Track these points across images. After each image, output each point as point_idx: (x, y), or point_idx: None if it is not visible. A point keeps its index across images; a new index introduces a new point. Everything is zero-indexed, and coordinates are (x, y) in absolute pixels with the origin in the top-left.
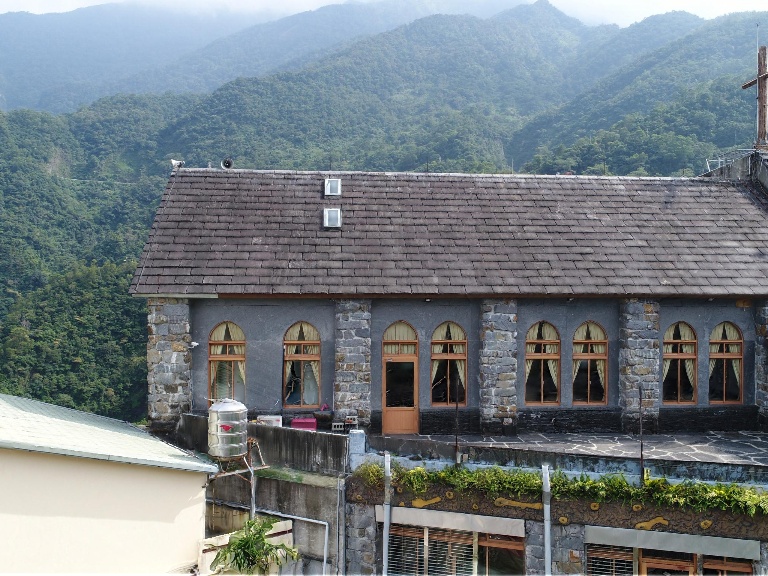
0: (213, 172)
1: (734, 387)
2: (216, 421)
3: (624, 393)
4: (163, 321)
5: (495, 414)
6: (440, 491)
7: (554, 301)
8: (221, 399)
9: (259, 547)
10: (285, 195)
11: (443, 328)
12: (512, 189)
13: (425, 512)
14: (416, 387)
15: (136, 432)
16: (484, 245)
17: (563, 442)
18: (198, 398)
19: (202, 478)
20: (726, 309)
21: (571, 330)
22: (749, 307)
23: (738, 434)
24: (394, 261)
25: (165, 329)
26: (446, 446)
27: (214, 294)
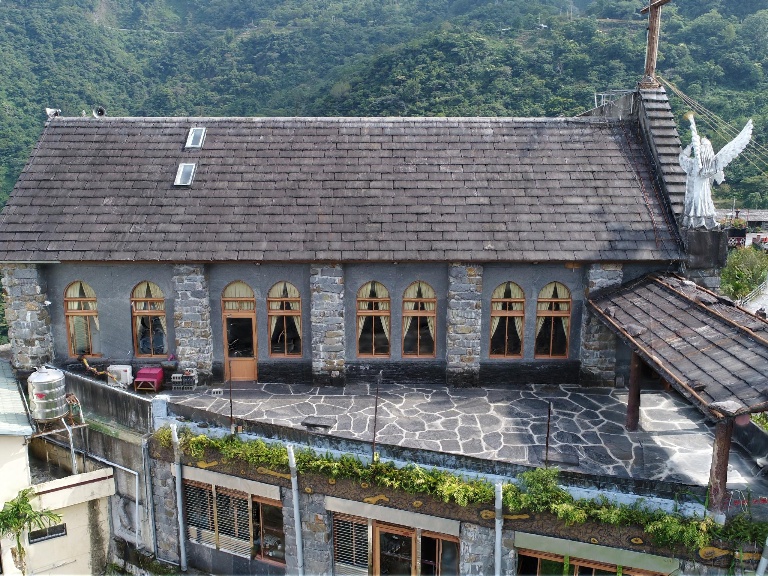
0: (85, 121)
1: (563, 342)
2: (31, 390)
3: (447, 349)
4: (15, 284)
5: (323, 367)
6: (217, 456)
7: (383, 262)
8: (41, 368)
9: (20, 517)
10: (148, 148)
11: (280, 286)
12: (375, 136)
13: (206, 472)
14: (255, 340)
15: (3, 379)
16: (324, 204)
17: (378, 396)
18: (59, 348)
19: (21, 438)
20: (555, 270)
21: (400, 289)
22: (579, 268)
23: (555, 388)
24: (231, 224)
25: (18, 291)
26: (225, 418)
27: (56, 261)
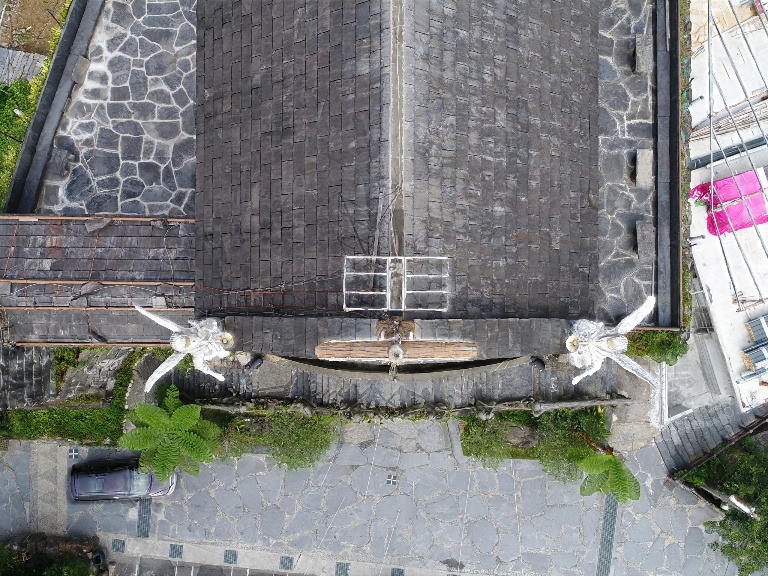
0: None
1: None
2: None
3: None
4: None
5: None
6: None
7: None
8: None
9: None
10: None
11: None
12: None
13: None
14: None
15: None
16: None
17: None
18: None
19: None
20: None
21: None
22: None
23: None
24: None
25: None
26: None
27: None
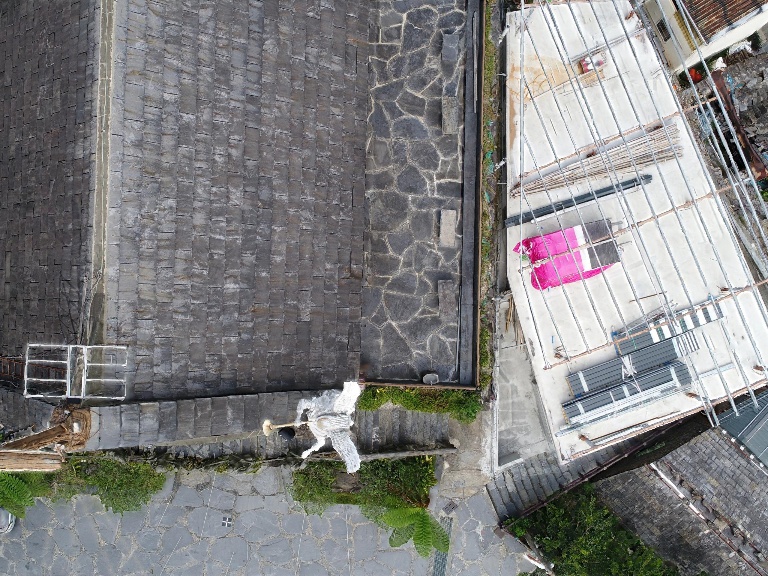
0: None
1: None
2: None
3: None
4: None
5: None
6: None
7: None
8: None
9: None
10: None
11: None
12: None
13: None
14: None
15: None
16: None
17: None
18: None
19: None
20: None
21: None
22: None
23: None
24: None
25: None
26: None
27: None
